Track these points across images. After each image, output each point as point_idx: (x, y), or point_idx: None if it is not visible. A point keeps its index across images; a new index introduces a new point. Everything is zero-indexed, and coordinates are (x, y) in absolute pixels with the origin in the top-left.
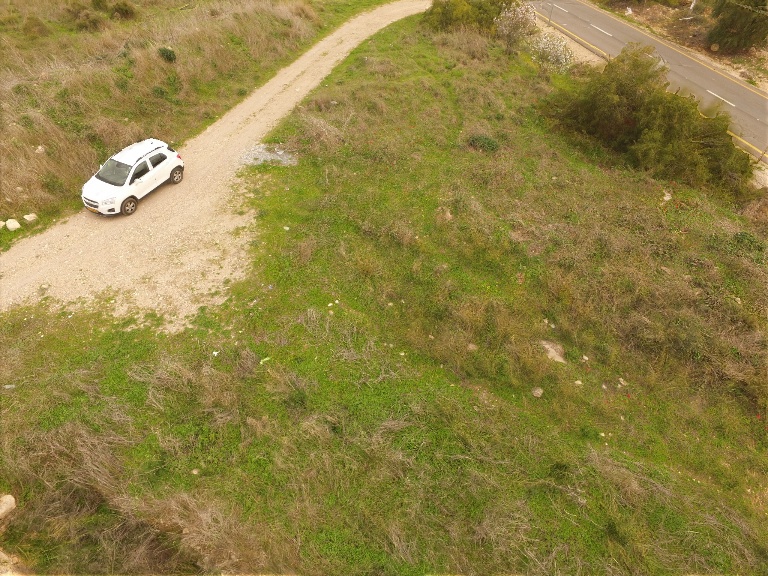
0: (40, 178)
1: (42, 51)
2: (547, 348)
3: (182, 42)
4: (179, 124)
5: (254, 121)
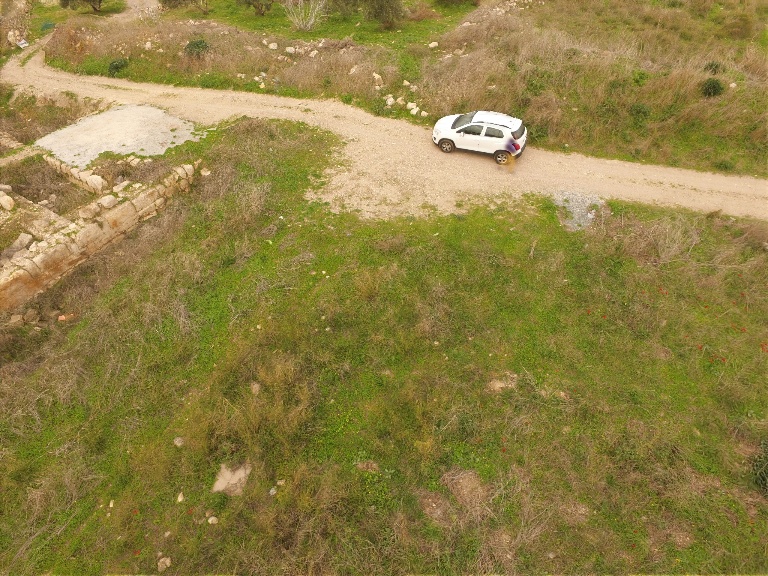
0: (460, 100)
1: (690, 46)
2: (234, 467)
3: (764, 88)
4: (603, 141)
5: (659, 188)
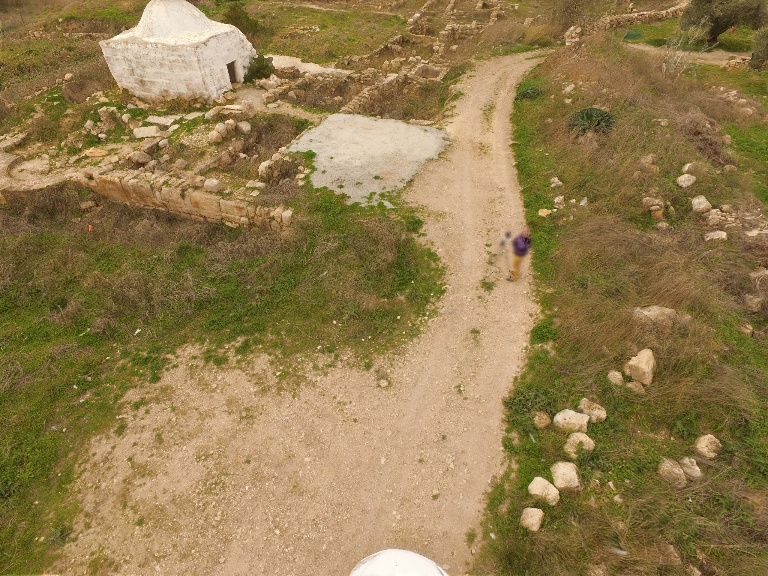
0: None
1: None
2: None
3: None
4: None
5: None
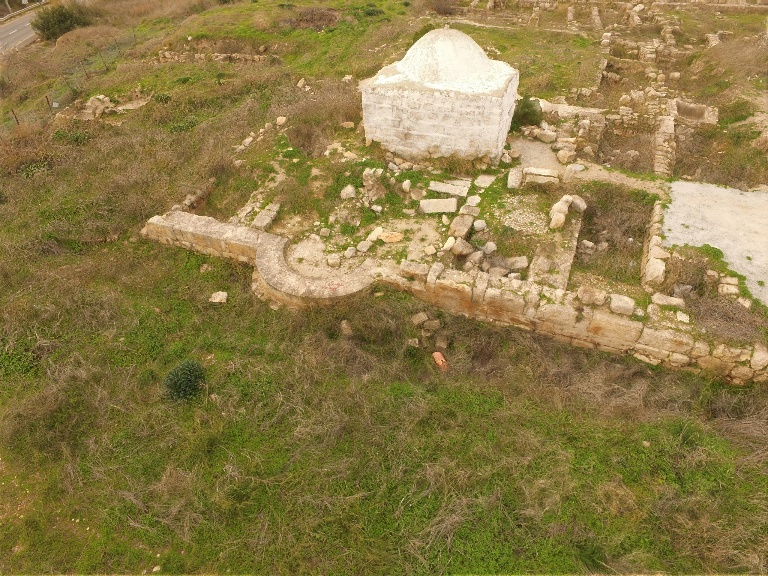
0: None
1: None
2: None
3: None
4: None
5: None
